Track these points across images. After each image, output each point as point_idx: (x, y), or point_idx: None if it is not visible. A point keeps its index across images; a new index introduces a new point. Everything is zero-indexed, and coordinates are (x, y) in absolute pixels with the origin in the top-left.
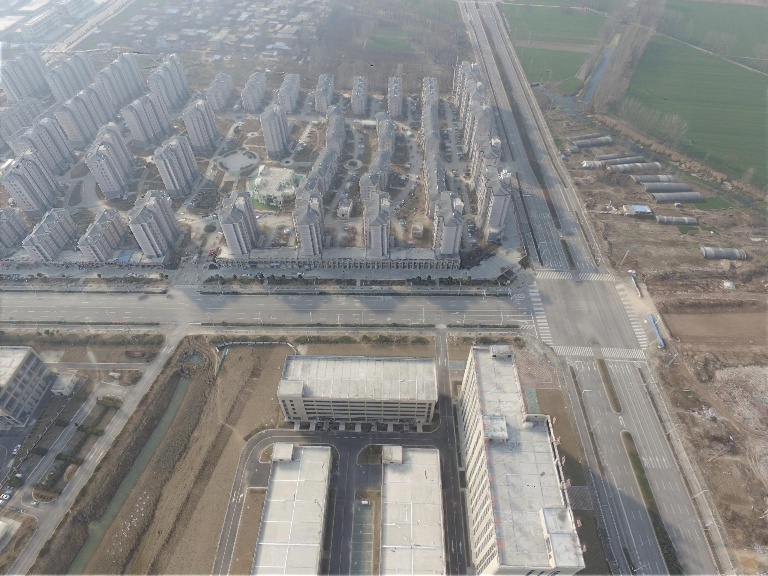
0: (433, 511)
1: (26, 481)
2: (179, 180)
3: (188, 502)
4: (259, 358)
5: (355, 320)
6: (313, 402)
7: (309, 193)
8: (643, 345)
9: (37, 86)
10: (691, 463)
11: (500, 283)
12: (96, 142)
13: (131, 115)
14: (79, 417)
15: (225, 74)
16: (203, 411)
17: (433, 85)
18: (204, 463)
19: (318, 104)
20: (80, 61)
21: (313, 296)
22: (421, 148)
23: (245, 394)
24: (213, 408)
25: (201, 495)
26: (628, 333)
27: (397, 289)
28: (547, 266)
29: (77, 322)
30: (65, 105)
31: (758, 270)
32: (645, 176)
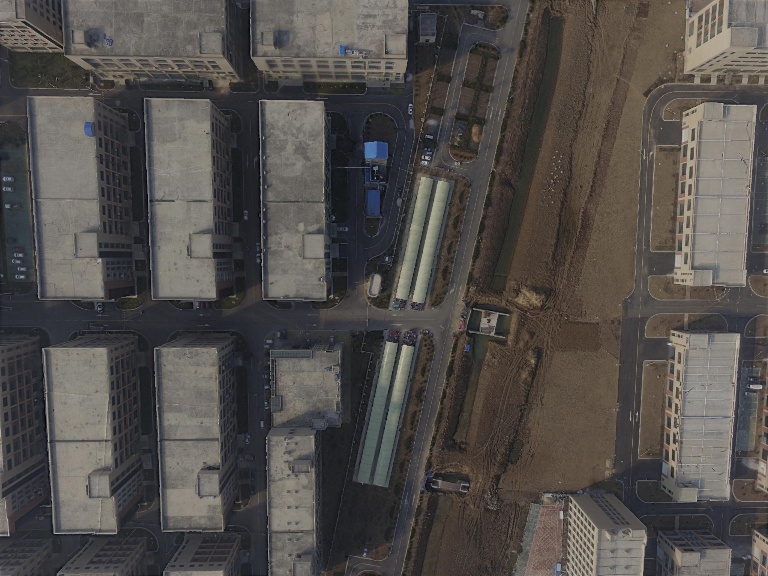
0: None
1: (438, 142)
2: None
3: (600, 160)
4: None
5: None
6: (754, 54)
7: None
8: None
9: None
10: None
11: None
12: None
13: None
14: (458, 70)
15: None
16: (591, 62)
17: None
18: (607, 121)
19: None
20: None
21: None
22: None
23: (635, 39)
24: (602, 58)
25: (611, 153)
26: None
27: None
28: None
29: None
30: None
31: None
32: None
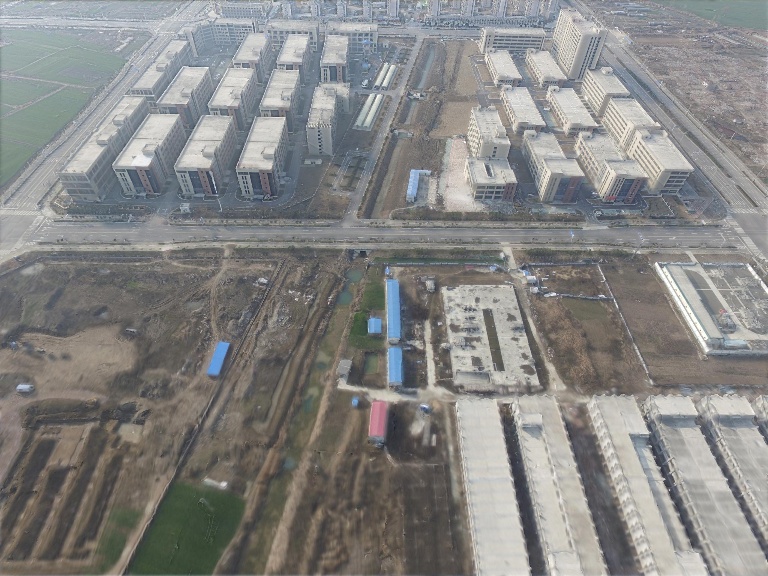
0: (550, 60)
1: None
2: None
3: None
4: (461, 42)
5: None
6: (498, 37)
7: None
8: (622, 43)
9: None
10: (641, 63)
11: None
12: None
13: None
14: (397, 52)
15: None
16: (447, 52)
17: None
18: (456, 61)
19: None
20: None
21: (474, 30)
22: None
23: (461, 49)
24: None
25: None
26: (616, 40)
27: None
28: None
29: None
30: None
31: (673, 27)
32: (622, 3)
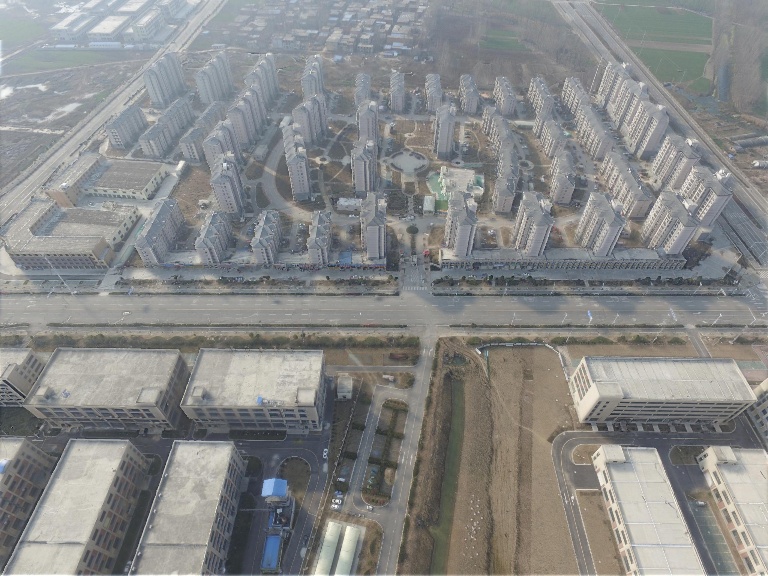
0: None
1: (350, 485)
2: (370, 181)
3: (521, 505)
4: (524, 360)
5: (601, 321)
6: (628, 403)
7: (533, 194)
8: None
9: (175, 87)
10: None
11: (729, 283)
12: (288, 143)
13: (304, 116)
14: (372, 420)
15: (366, 75)
16: (492, 413)
17: (580, 85)
18: (519, 465)
19: (468, 104)
20: (222, 62)
21: (548, 297)
22: (585, 148)
23: (527, 396)
24: (501, 410)
25: (531, 497)
26: None
27: (628, 289)
28: (766, 266)
29: (324, 325)
30: (238, 106)
31: None
32: None
